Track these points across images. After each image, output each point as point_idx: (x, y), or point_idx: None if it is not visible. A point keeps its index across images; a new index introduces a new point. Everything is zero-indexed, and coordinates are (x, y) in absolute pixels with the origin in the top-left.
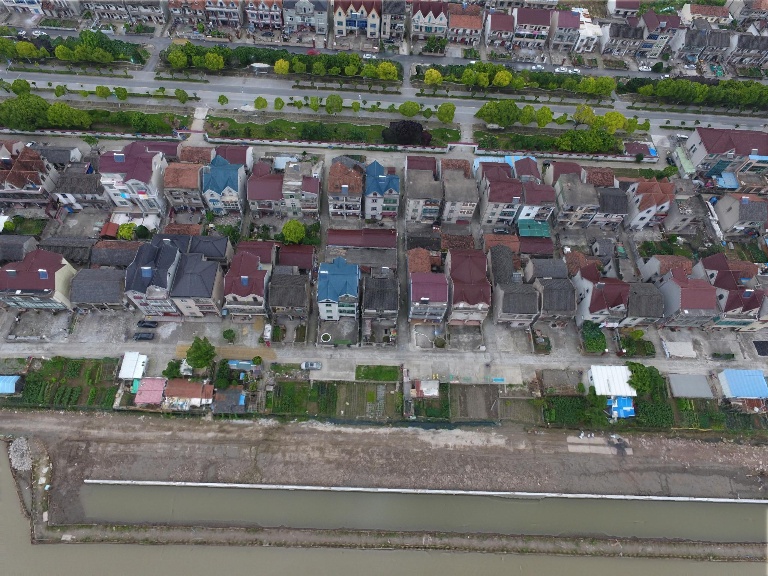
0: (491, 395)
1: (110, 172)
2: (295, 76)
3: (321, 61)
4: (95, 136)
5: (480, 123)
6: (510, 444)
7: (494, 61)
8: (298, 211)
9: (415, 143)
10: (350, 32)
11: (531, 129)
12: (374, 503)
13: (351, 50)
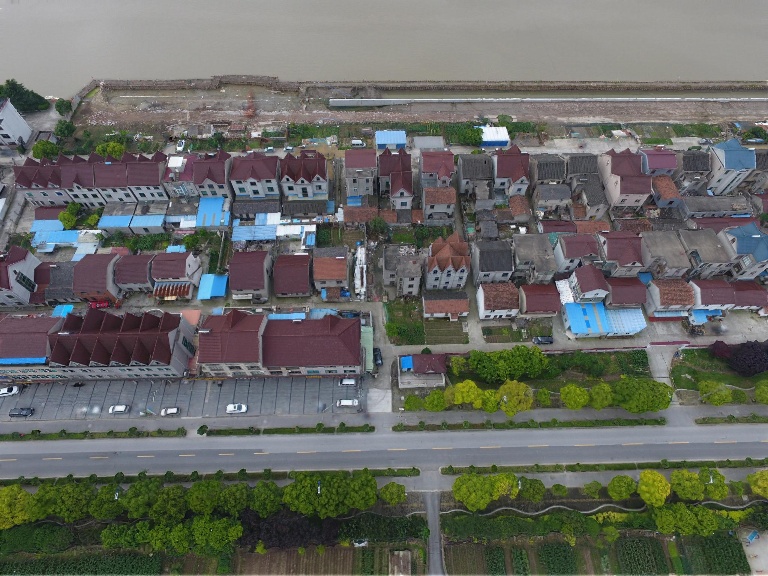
0: None
1: None
2: None
3: None
4: None
5: None
6: (554, 118)
7: None
8: None
9: None
10: None
11: None
12: None
13: None
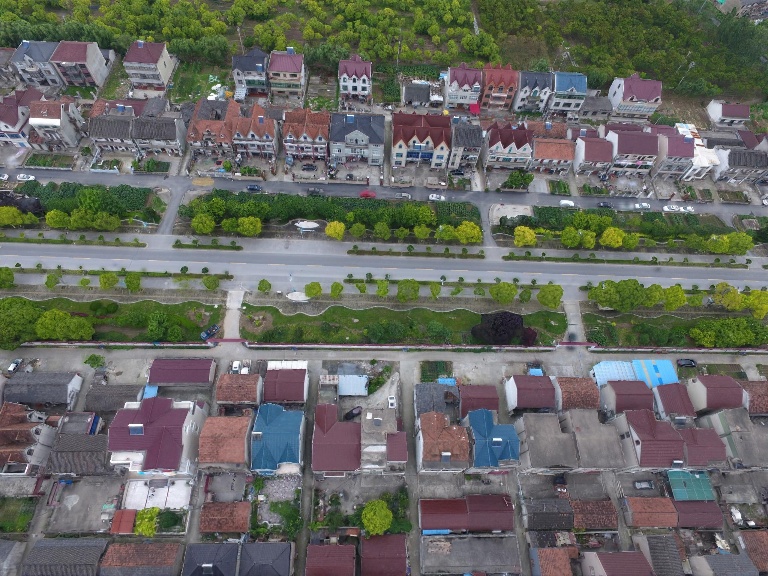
0: None
1: (124, 449)
2: (350, 234)
3: (384, 218)
4: (99, 345)
5: (588, 300)
6: None
7: (588, 197)
8: (377, 472)
9: (513, 338)
10: (410, 161)
11: (653, 307)
12: None
13: (413, 187)
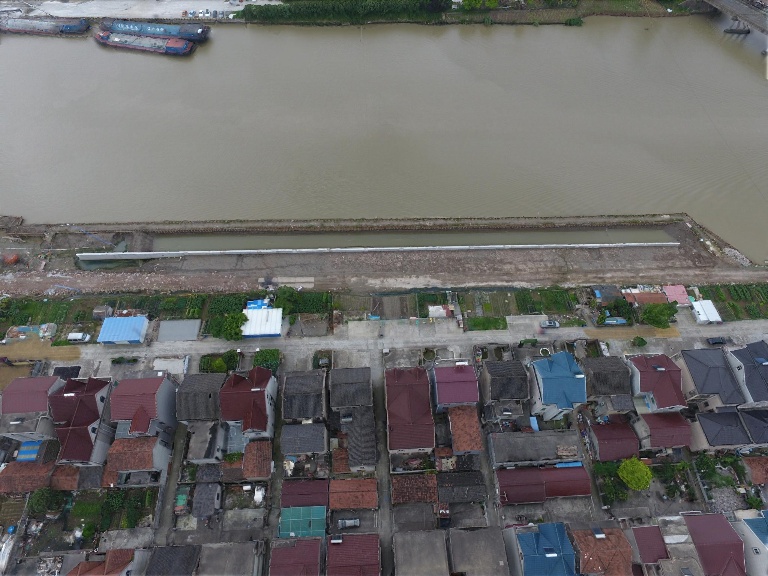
0: (378, 314)
1: None
2: None
3: None
4: None
5: None
6: (364, 280)
7: None
8: None
9: None
10: None
11: None
12: (469, 244)
13: None
